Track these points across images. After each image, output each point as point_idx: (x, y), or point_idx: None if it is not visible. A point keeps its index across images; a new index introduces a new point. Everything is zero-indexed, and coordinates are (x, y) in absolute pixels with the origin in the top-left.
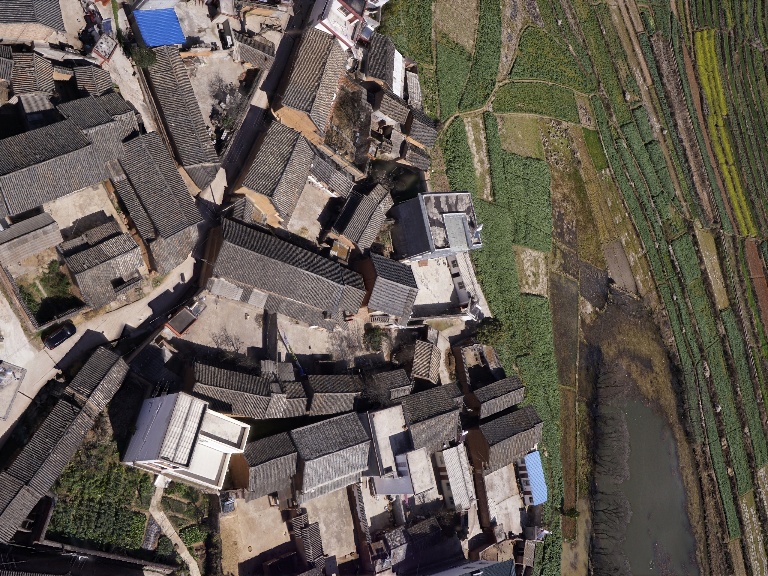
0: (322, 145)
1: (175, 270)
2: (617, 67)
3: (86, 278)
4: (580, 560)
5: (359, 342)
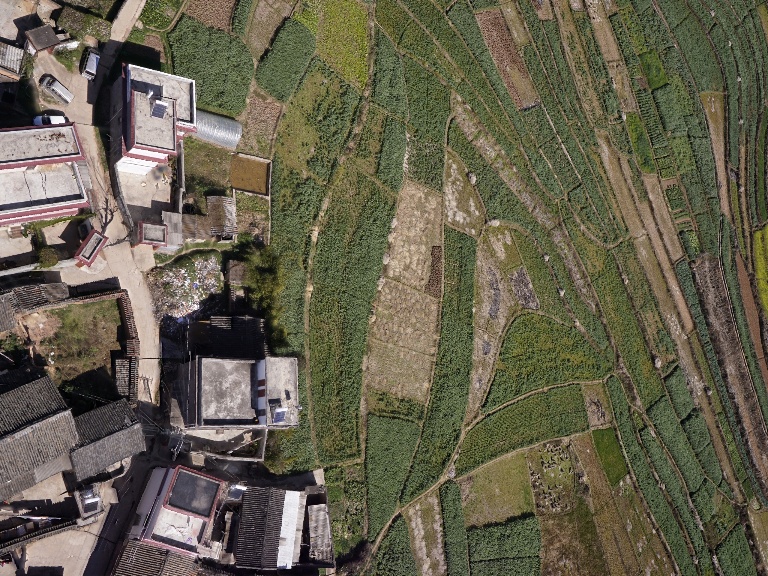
0: None
1: None
2: (644, 325)
3: None
4: None
5: None
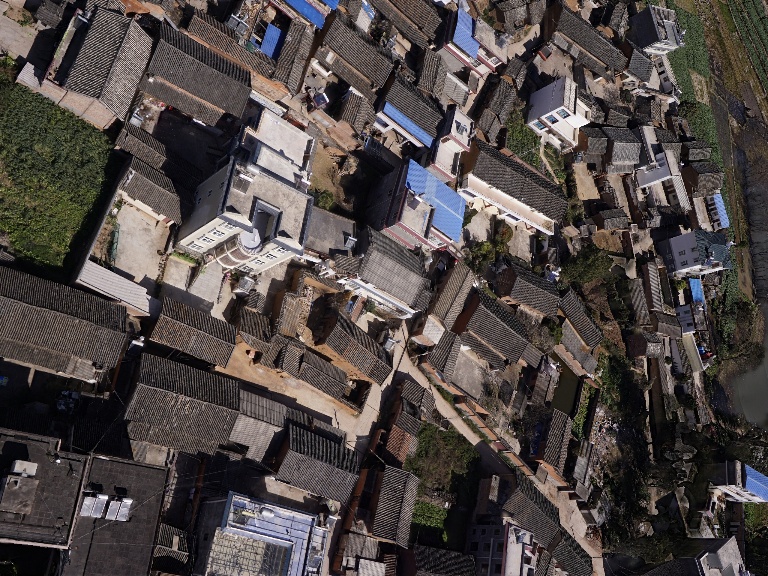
0: None
1: (532, 29)
2: None
3: (507, 16)
4: (747, 282)
5: (618, 97)
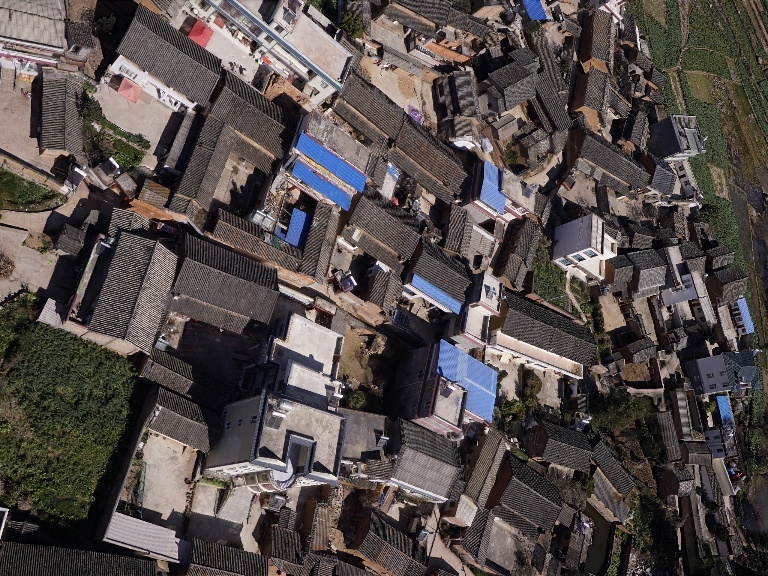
0: None
1: None
2: (750, 38)
3: (531, 151)
4: None
5: (641, 212)
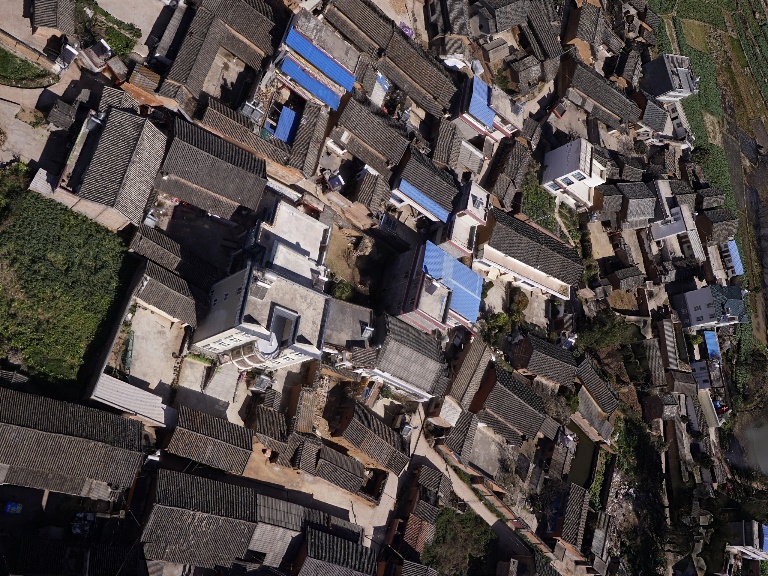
0: None
1: (546, 85)
2: None
3: (522, 76)
4: (761, 327)
5: (632, 148)
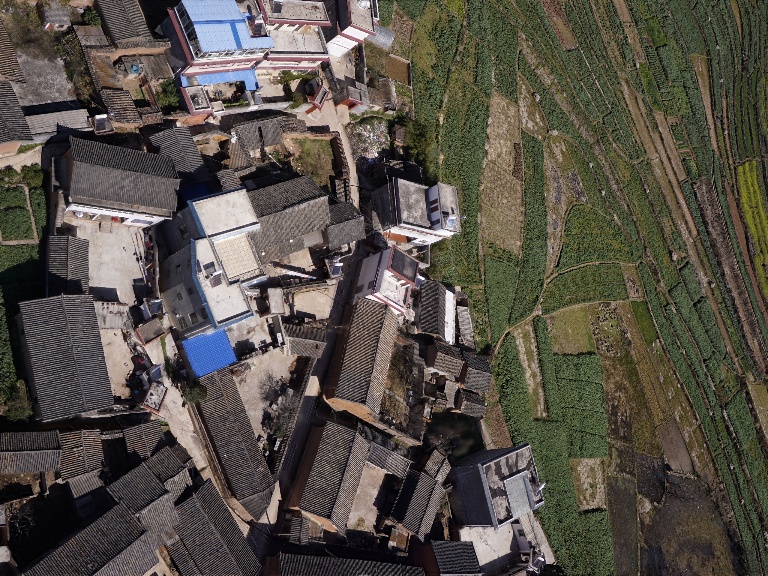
0: (376, 423)
1: None
2: (662, 226)
3: None
4: None
5: None
